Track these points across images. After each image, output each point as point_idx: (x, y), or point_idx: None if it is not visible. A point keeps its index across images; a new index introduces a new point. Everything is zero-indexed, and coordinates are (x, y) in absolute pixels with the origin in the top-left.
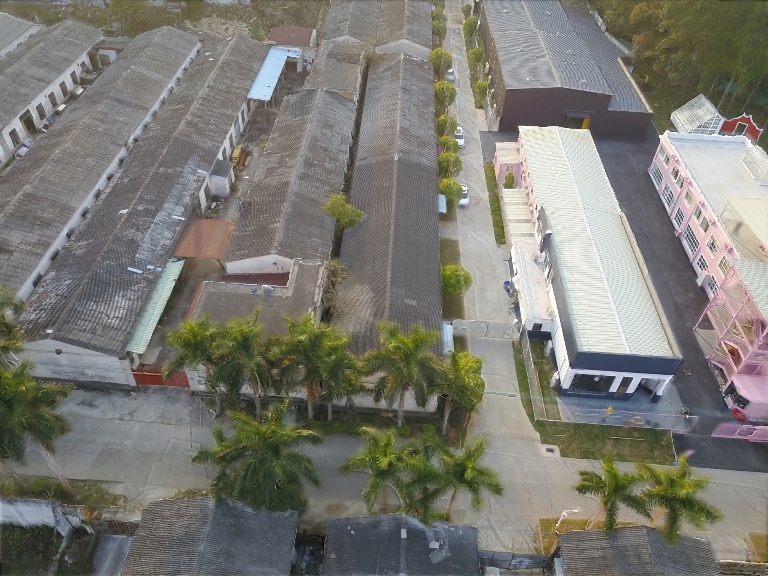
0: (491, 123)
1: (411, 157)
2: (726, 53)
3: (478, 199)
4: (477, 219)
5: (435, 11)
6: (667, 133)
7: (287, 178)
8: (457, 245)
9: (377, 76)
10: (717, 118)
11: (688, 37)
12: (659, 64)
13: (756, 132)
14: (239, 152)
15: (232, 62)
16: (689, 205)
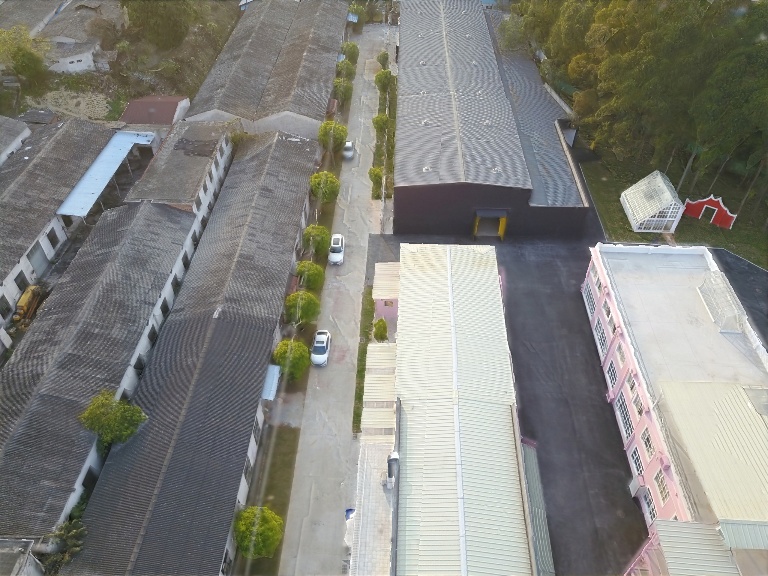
0: (382, 225)
1: (241, 307)
2: (684, 121)
3: (343, 351)
4: (334, 387)
5: (341, 64)
6: (599, 247)
7: (42, 366)
8: (296, 438)
9: (240, 168)
10: (675, 206)
11: (631, 106)
12: (602, 133)
13: (728, 218)
14: (28, 297)
15: (50, 161)
16: (622, 364)
